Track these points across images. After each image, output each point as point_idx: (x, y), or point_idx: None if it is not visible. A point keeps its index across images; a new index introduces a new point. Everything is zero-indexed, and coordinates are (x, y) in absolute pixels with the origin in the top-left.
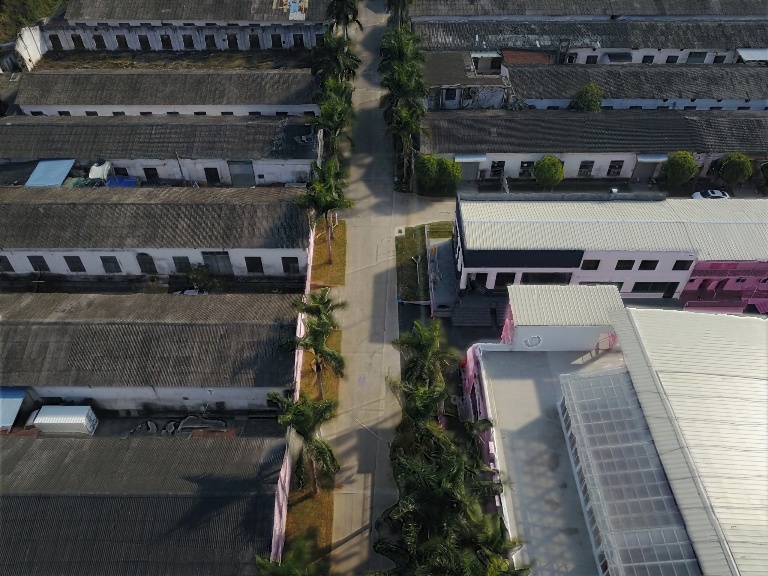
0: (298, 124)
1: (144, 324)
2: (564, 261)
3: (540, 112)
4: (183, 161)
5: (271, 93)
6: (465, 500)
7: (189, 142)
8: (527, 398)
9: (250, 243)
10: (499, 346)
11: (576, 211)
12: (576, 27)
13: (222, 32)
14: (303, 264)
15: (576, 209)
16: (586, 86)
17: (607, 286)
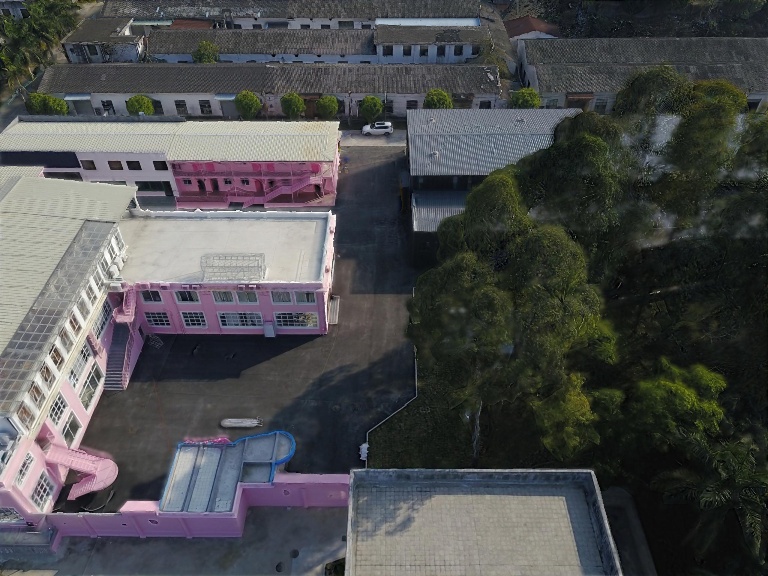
0: None
1: None
2: (66, 162)
3: None
4: None
5: None
6: None
7: None
8: None
9: None
10: None
11: (102, 128)
12: (245, 1)
13: None
14: None
15: (104, 127)
16: None
17: (37, 167)
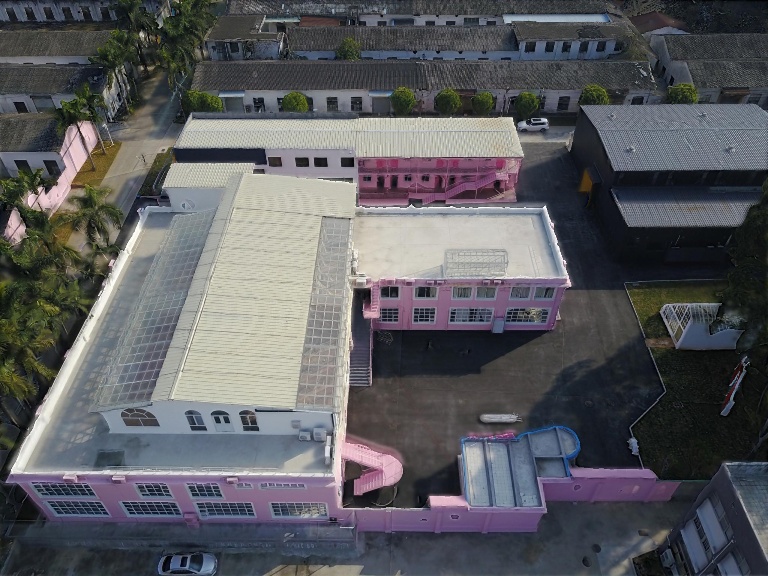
0: (93, 67)
1: None
2: (253, 159)
3: (305, 61)
4: None
5: (87, 47)
6: (16, 258)
7: (1, 81)
8: None
9: (16, 148)
10: (162, 208)
11: (279, 125)
12: None
13: (76, 5)
14: (62, 167)
15: (280, 123)
16: (343, 39)
17: (247, 163)
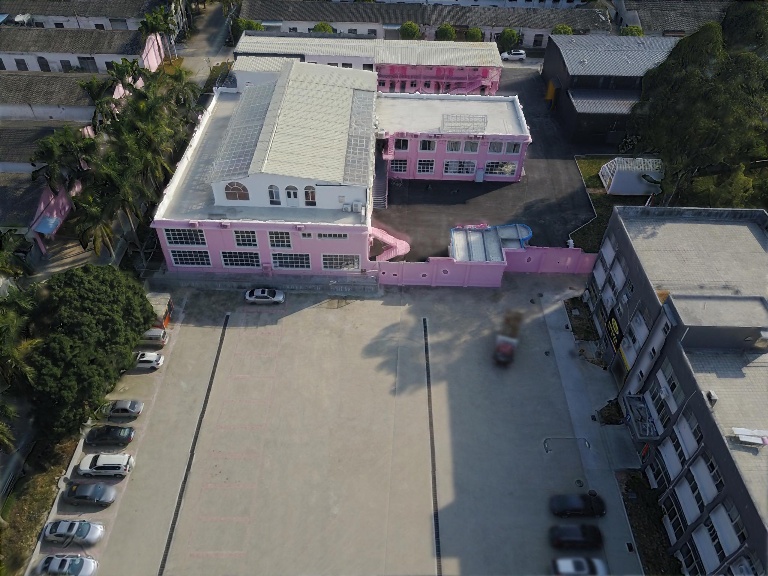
0: None
1: (29, 76)
2: None
3: None
4: (80, 18)
5: None
6: None
7: (85, 7)
8: None
9: (107, 51)
10: (230, 89)
11: None
12: None
13: None
14: None
15: (315, 40)
16: None
17: (295, 58)
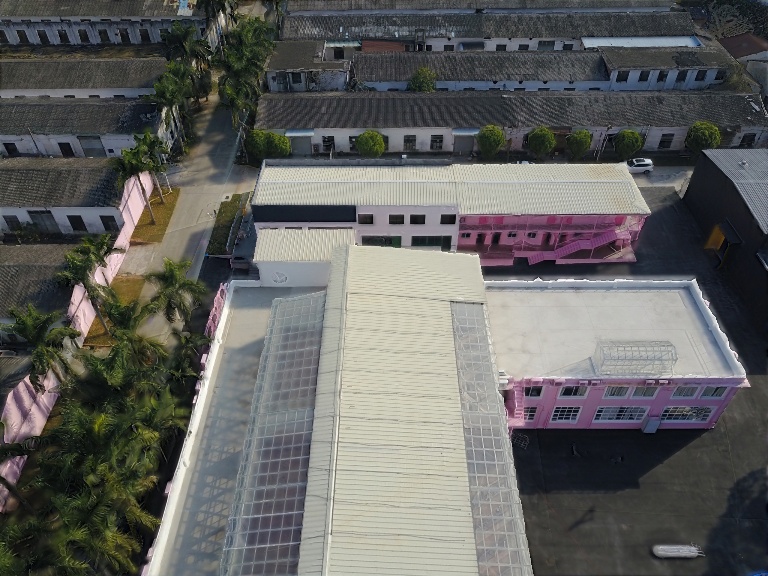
0: (145, 103)
1: None
2: (341, 216)
3: (375, 93)
4: (37, 136)
5: (133, 78)
6: (109, 377)
7: (44, 120)
8: (259, 323)
9: (69, 202)
10: (250, 282)
11: (365, 174)
12: (434, 19)
13: (114, 27)
14: (120, 222)
15: (366, 172)
16: (418, 69)
17: (347, 230)
